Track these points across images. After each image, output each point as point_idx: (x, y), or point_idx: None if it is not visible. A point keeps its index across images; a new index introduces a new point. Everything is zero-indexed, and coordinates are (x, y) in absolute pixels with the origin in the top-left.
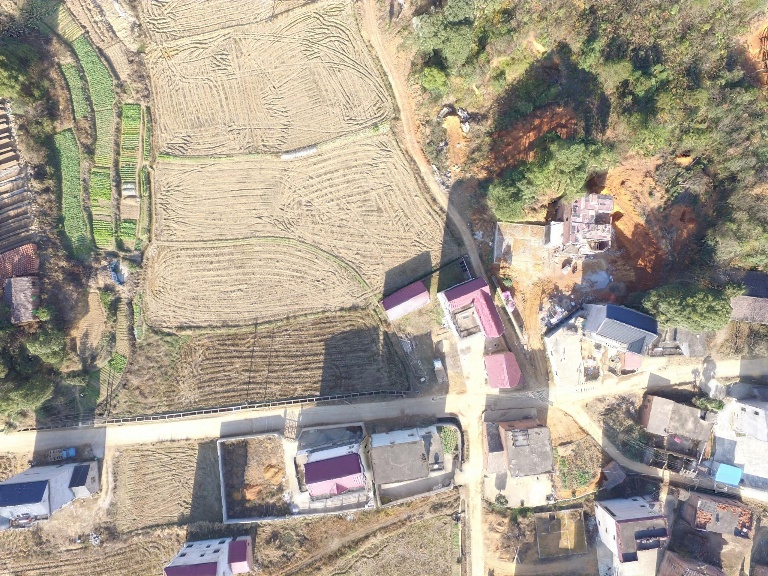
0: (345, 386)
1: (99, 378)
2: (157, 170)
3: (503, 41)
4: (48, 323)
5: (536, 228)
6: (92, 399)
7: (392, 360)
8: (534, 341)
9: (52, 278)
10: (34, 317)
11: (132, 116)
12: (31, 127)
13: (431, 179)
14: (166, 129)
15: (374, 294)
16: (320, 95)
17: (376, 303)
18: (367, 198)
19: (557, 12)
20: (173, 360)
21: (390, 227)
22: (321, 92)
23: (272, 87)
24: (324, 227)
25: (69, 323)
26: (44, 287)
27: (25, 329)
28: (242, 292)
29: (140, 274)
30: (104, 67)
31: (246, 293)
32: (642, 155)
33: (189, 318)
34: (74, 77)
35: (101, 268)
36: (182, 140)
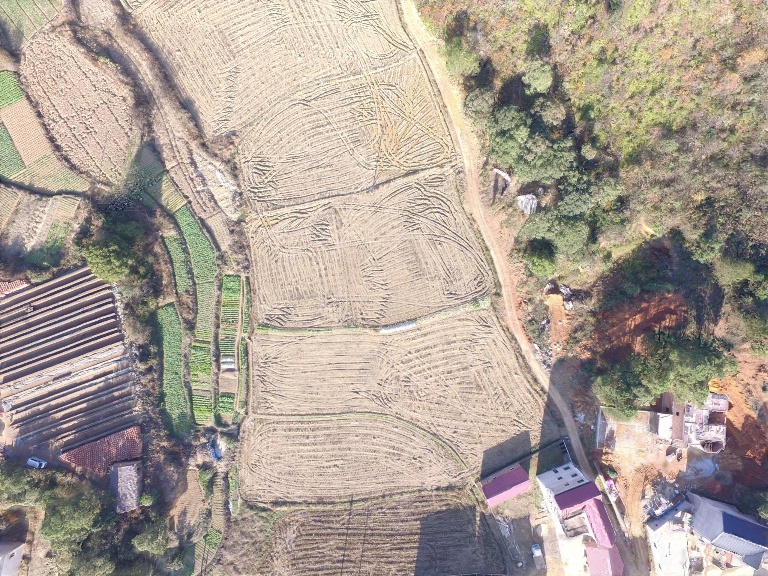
0: (440, 567)
1: (194, 553)
2: (255, 341)
3: (615, 230)
4: (152, 510)
5: (640, 413)
6: (186, 574)
7: (488, 542)
8: (635, 529)
9: (154, 459)
10: (138, 505)
11: (232, 288)
12: (137, 308)
13: (532, 358)
14: (265, 300)
15: (472, 474)
16: (420, 268)
17: (473, 483)
18: (466, 375)
19: (672, 202)
20: (267, 535)
21: (489, 405)
22: (421, 265)
23: (372, 259)
24: (422, 404)
25: (169, 504)
26: (147, 471)
27: (127, 512)
28: (338, 468)
29: (236, 447)
30: (206, 239)
31: (342, 469)
32: (756, 349)
33: (284, 493)
34: (177, 250)
35: (200, 445)
36: (281, 312)
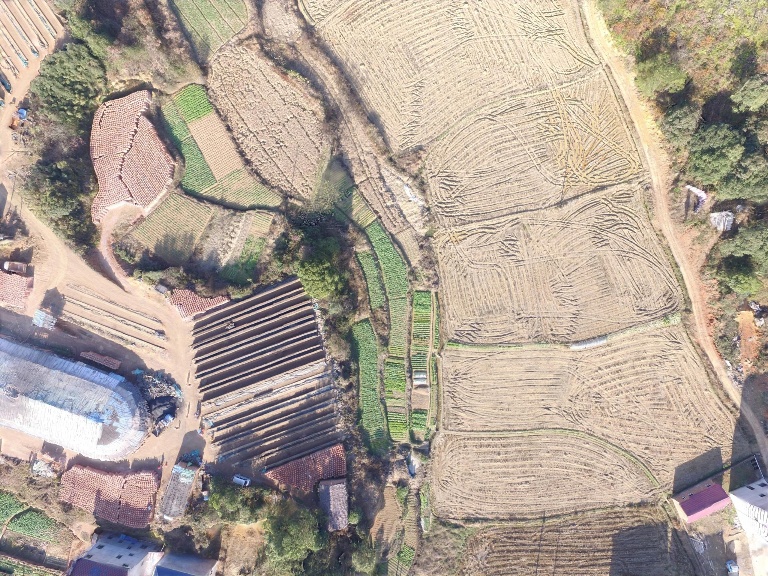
0: None
1: (387, 570)
2: (445, 357)
3: None
4: (360, 529)
5: None
6: None
7: (680, 558)
8: None
9: (356, 477)
10: None
11: (423, 303)
12: (340, 325)
13: (723, 374)
14: (454, 315)
15: (664, 490)
16: (609, 284)
17: (665, 499)
18: (656, 391)
19: None
20: (459, 552)
21: (680, 422)
22: (610, 281)
23: (561, 275)
24: (613, 420)
25: (371, 522)
26: (352, 488)
27: None
28: (530, 484)
29: (428, 463)
30: (398, 255)
31: (534, 485)
32: None
33: (476, 509)
34: (370, 266)
35: (397, 462)
36: (471, 327)
